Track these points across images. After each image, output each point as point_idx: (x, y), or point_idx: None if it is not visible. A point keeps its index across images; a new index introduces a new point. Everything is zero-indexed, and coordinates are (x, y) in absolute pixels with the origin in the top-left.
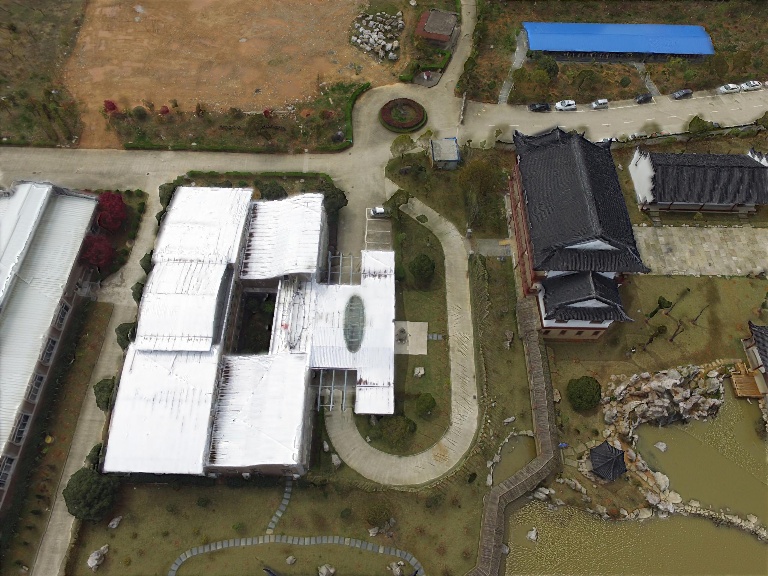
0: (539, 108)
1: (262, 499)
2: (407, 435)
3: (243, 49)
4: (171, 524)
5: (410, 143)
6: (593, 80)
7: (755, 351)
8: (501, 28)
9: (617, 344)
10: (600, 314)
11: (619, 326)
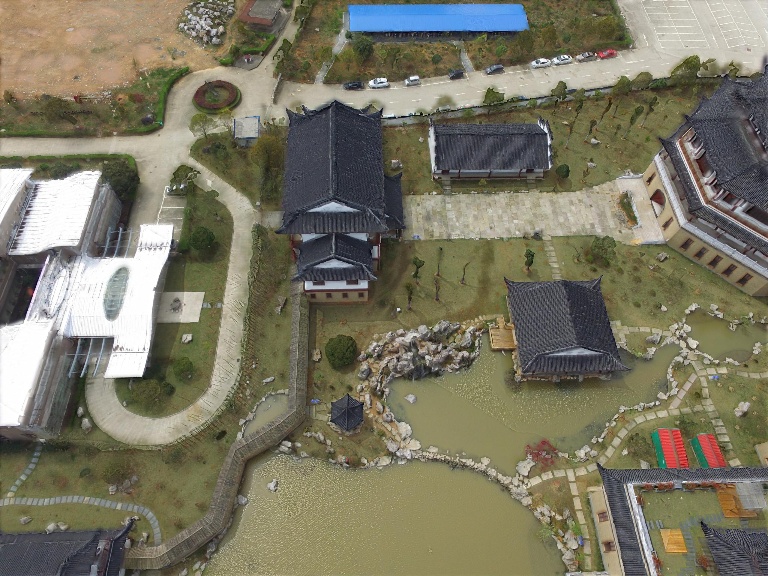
0: (352, 86)
1: (9, 465)
2: (164, 398)
3: (69, 38)
4: None
5: (209, 122)
6: (406, 58)
7: None
8: (330, 12)
9: (385, 305)
10: (348, 274)
11: (391, 288)
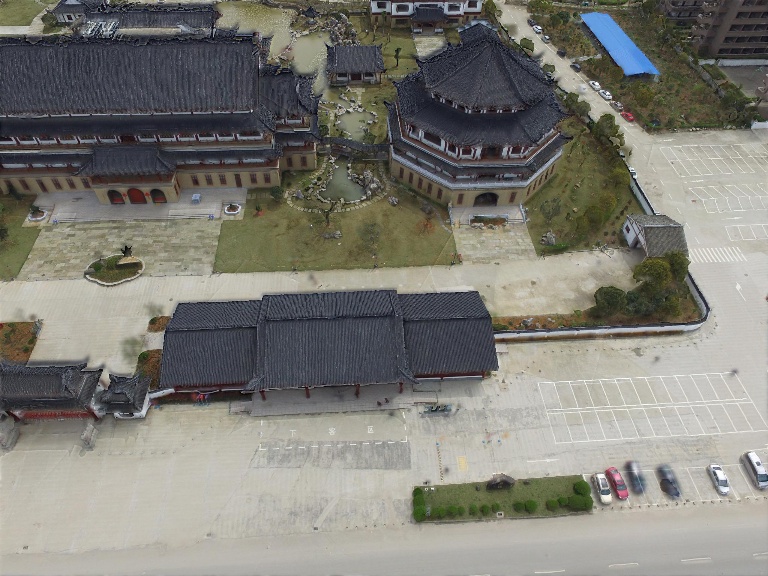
0: (529, 20)
1: None
2: None
3: None
4: None
5: None
6: None
7: None
8: None
9: (370, 29)
10: None
11: None
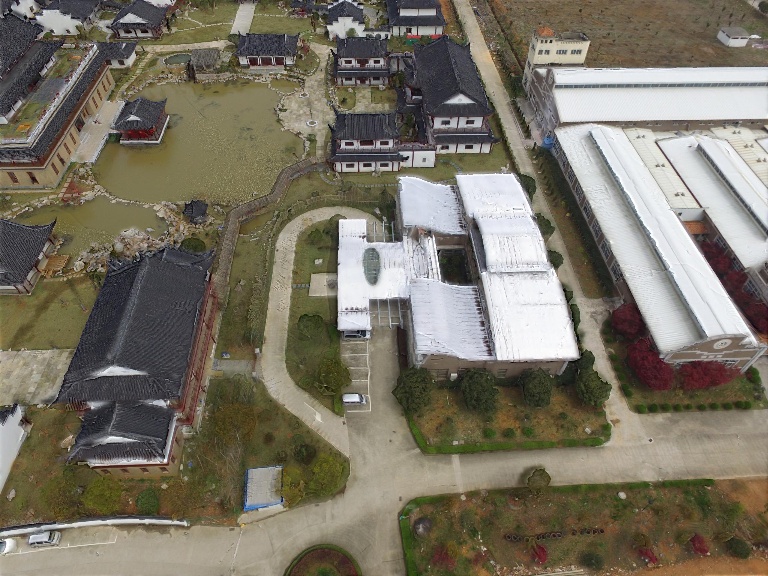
0: None
1: None
2: (330, 228)
3: None
4: None
5: None
6: None
7: None
8: None
9: None
10: None
11: None
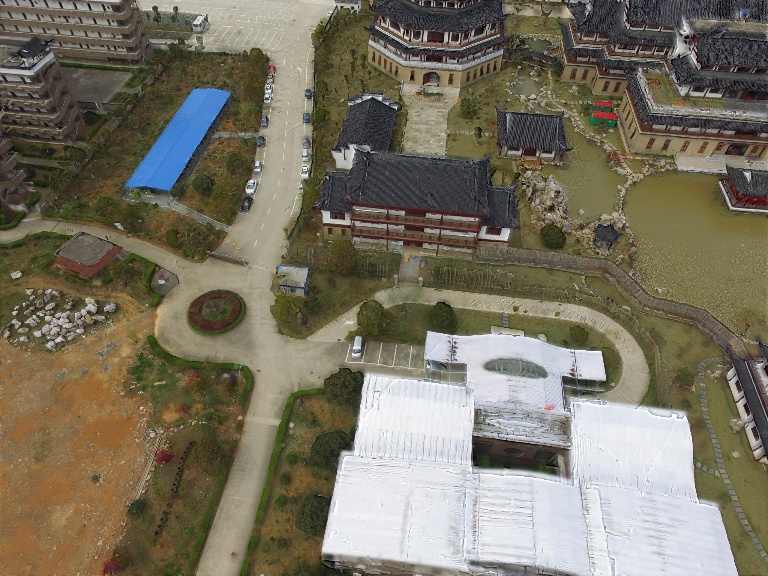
0: (249, 204)
1: None
2: None
3: None
4: (743, 574)
5: None
6: None
7: (509, 153)
8: (113, 209)
9: None
10: (511, 200)
11: None
